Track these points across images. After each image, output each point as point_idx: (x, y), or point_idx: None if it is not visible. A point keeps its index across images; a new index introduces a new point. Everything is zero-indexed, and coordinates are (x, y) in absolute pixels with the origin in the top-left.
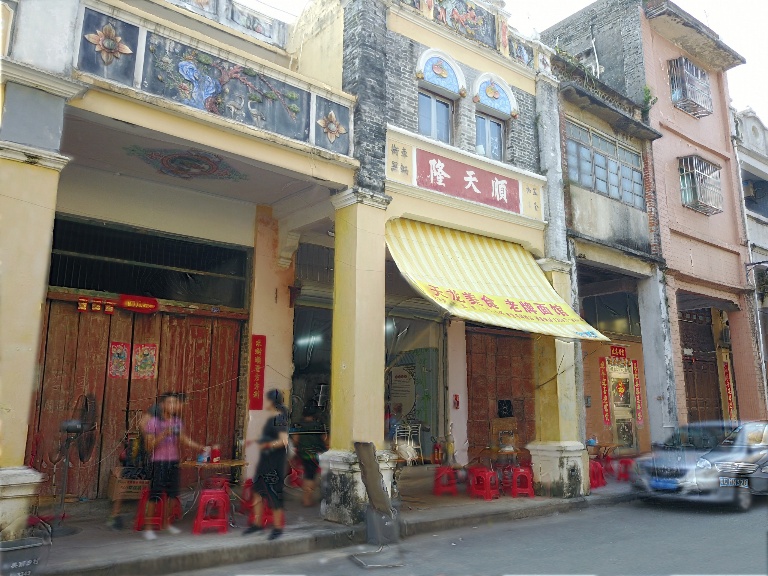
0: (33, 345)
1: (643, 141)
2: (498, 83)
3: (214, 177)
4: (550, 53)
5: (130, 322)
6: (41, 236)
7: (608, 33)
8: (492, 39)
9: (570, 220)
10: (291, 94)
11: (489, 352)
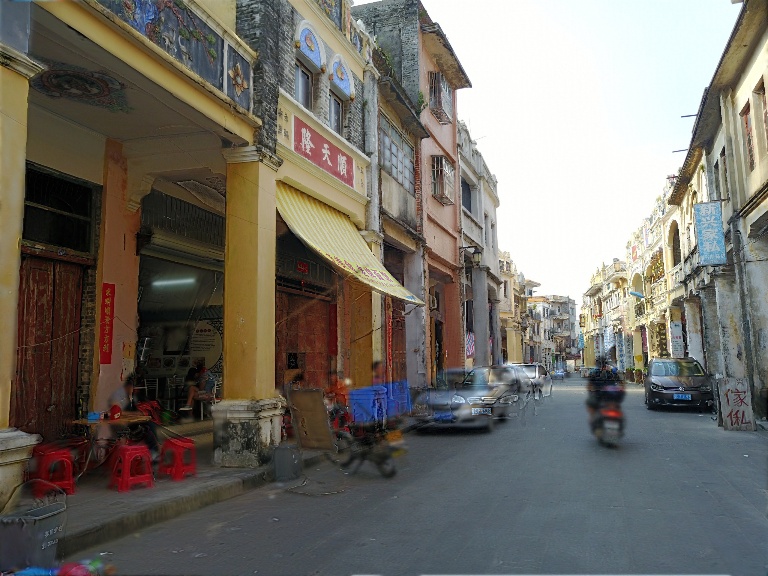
0: (12, 287)
1: (416, 138)
2: (344, 66)
3: (89, 102)
4: (373, 47)
5: None
6: (15, 157)
7: (388, 34)
8: (340, 22)
9: (381, 199)
10: (210, 37)
11: (283, 309)
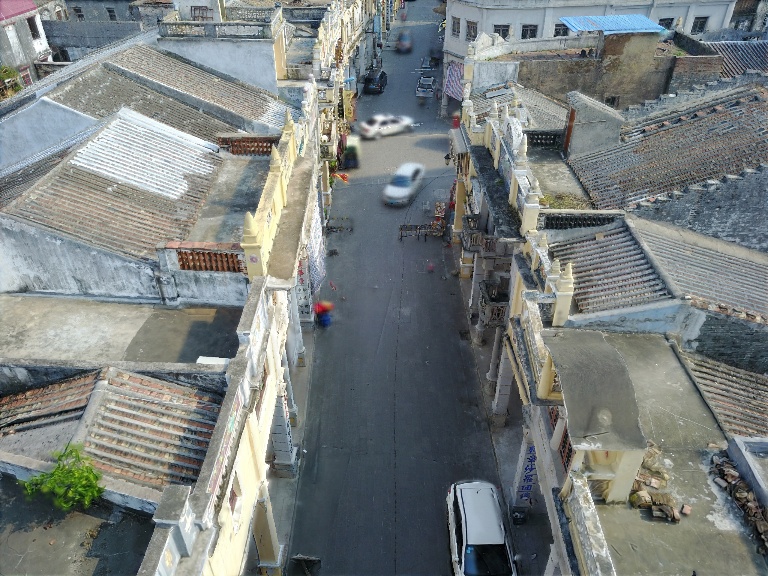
0: None
1: None
2: None
3: None
4: None
5: None
6: None
7: None
8: None
9: None
10: None
11: None
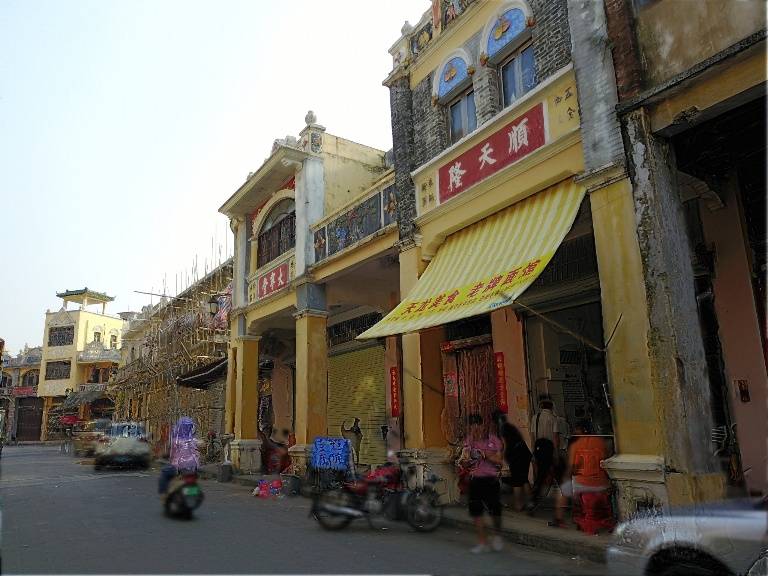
0: (305, 394)
1: None
2: (506, 10)
3: None
4: None
5: (454, 359)
6: None
7: None
8: None
9: (630, 83)
10: None
11: None
